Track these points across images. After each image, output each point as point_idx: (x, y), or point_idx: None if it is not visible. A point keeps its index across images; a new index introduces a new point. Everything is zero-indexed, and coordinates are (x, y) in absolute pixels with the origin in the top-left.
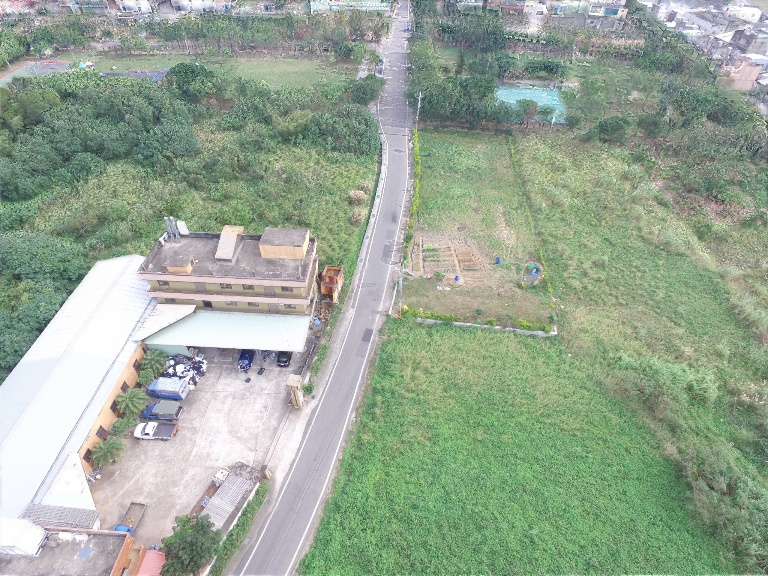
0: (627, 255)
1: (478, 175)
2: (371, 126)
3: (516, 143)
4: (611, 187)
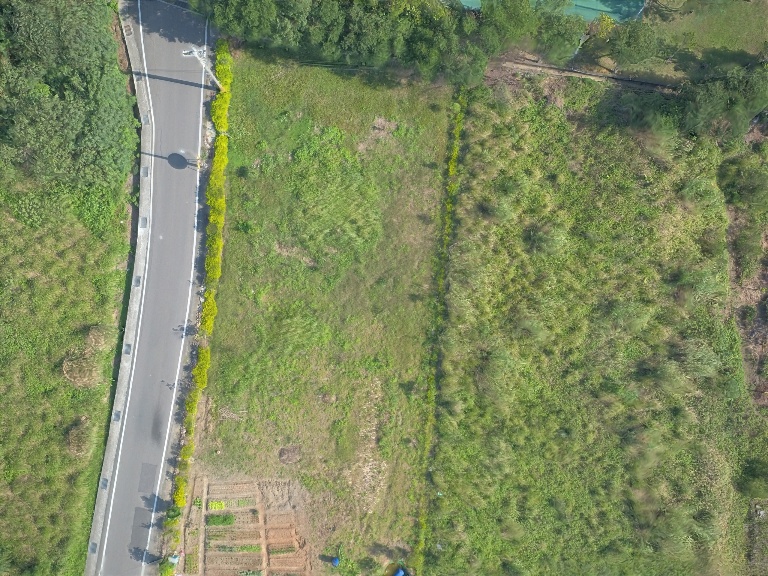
0: (586, 540)
1: (353, 257)
2: (98, 100)
3: (471, 115)
4: (634, 331)
